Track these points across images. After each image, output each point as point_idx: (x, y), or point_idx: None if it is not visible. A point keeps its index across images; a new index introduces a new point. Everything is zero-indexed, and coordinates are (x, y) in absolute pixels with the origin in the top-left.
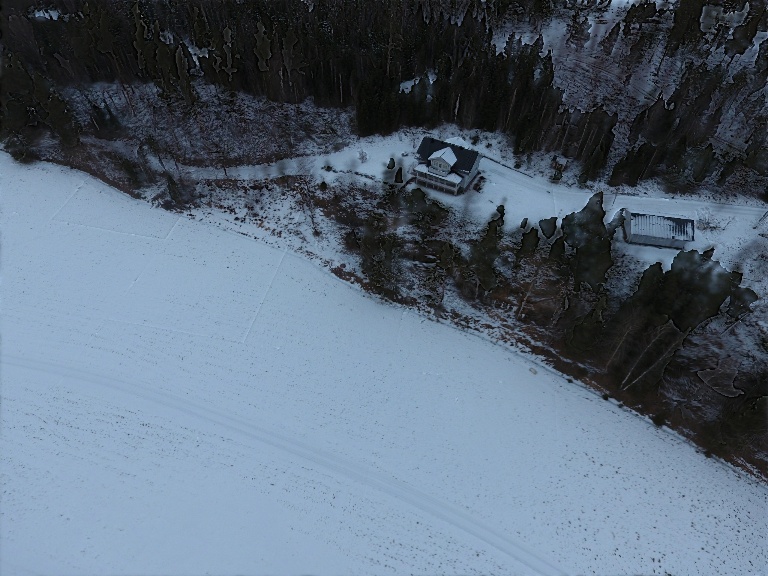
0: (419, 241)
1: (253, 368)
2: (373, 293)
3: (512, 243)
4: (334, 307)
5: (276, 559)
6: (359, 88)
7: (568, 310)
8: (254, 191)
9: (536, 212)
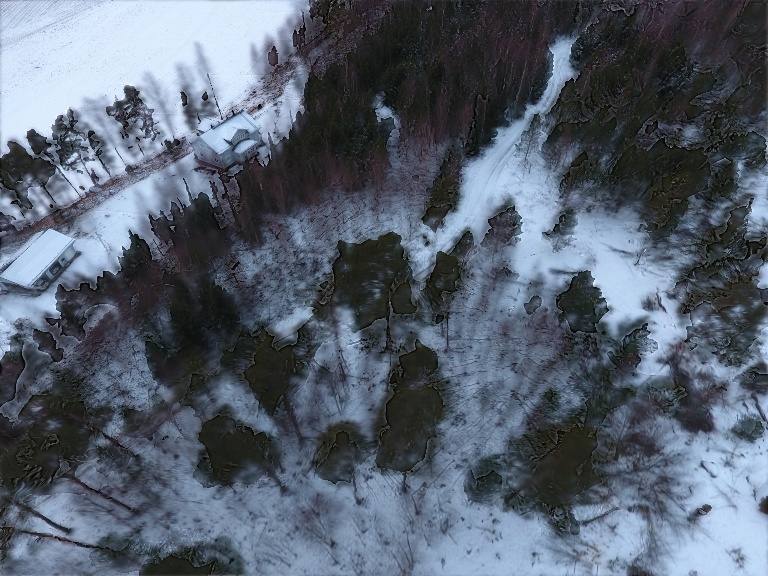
0: None
1: None
2: None
3: None
4: (150, 140)
5: (6, 138)
6: None
7: None
8: None
9: (140, 200)
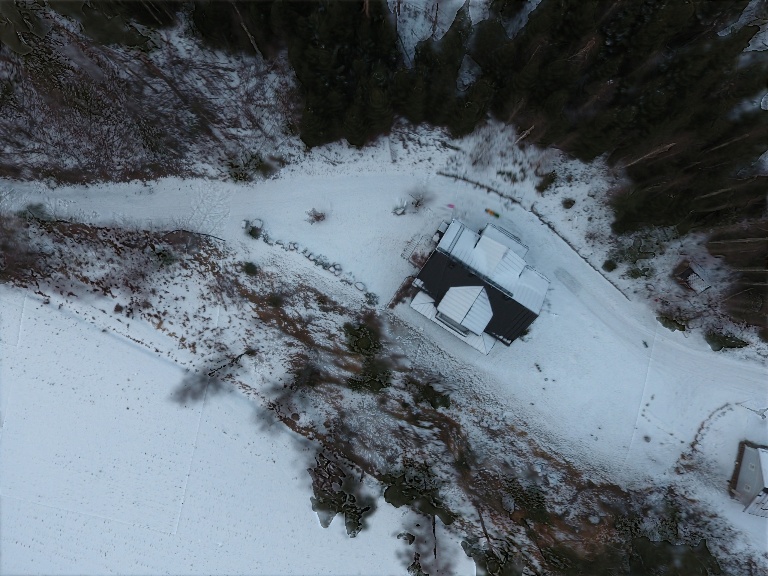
0: (410, 403)
1: (194, 572)
2: (340, 456)
3: (552, 452)
4: (287, 482)
5: None
6: (295, 60)
7: (599, 560)
8: (132, 251)
9: (608, 402)
